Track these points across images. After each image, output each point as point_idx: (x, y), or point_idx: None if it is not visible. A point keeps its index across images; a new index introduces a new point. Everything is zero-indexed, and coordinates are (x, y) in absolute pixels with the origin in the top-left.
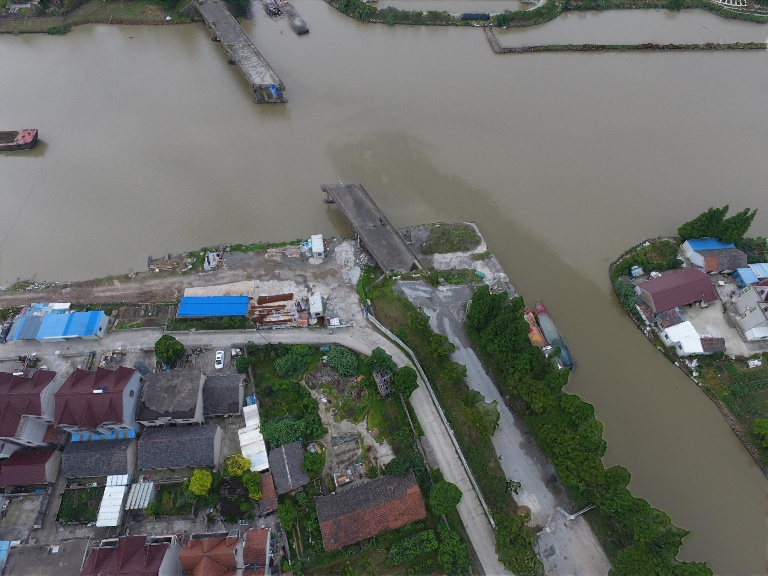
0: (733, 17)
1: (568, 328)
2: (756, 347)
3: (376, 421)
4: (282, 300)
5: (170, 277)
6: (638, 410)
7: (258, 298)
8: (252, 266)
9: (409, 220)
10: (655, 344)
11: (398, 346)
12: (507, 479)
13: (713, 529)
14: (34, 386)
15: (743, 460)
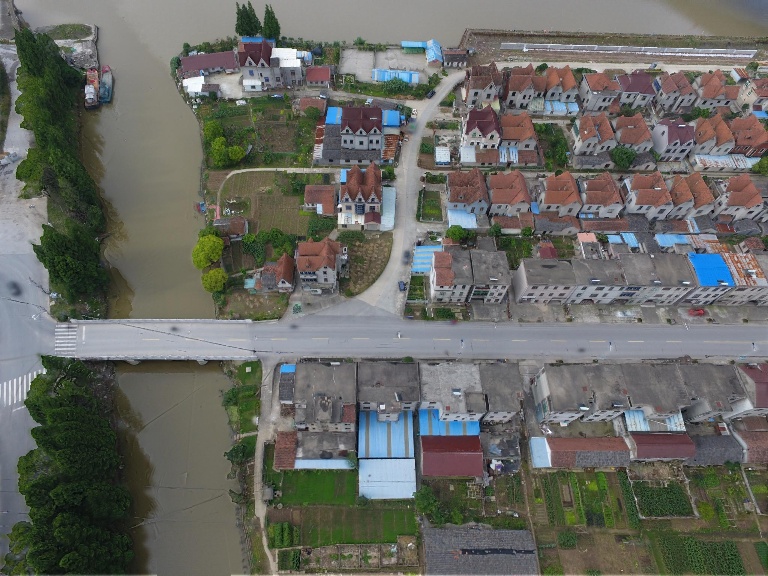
0: None
1: (129, 86)
2: (249, 95)
3: None
4: None
5: None
6: (159, 135)
7: None
8: None
9: (49, 24)
10: (180, 93)
11: None
12: (5, 140)
13: (168, 192)
14: None
15: (198, 151)
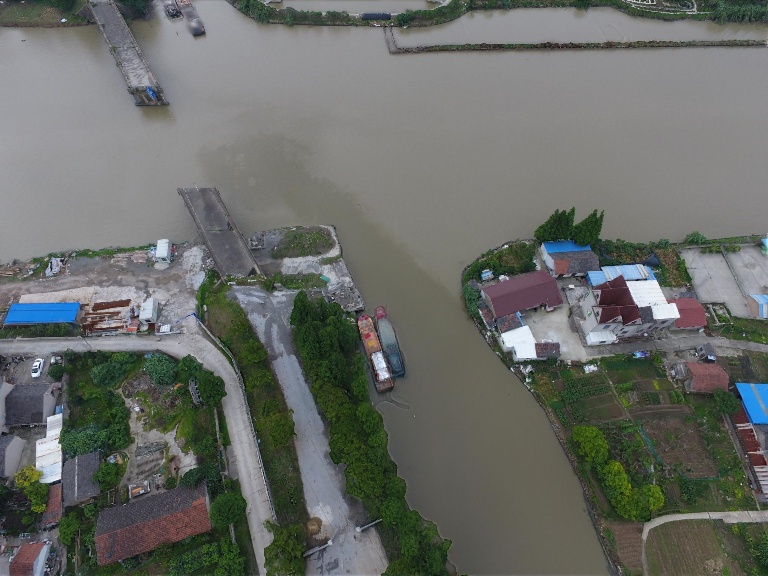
0: (640, 15)
1: (411, 333)
2: (595, 352)
3: (185, 430)
4: (118, 306)
5: (9, 283)
6: (473, 417)
7: (94, 304)
8: (95, 272)
9: (268, 224)
10: (494, 349)
11: (223, 353)
12: (304, 490)
13: (528, 539)
14: None
15: (563, 468)
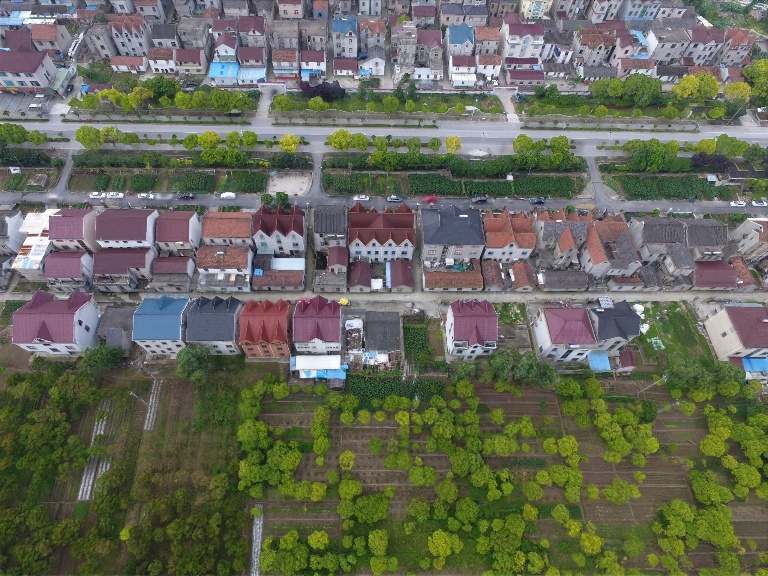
0: None
1: None
2: None
3: (759, 28)
4: None
5: None
6: None
7: None
8: None
9: None
10: None
11: (754, 7)
12: None
13: None
14: None
15: None
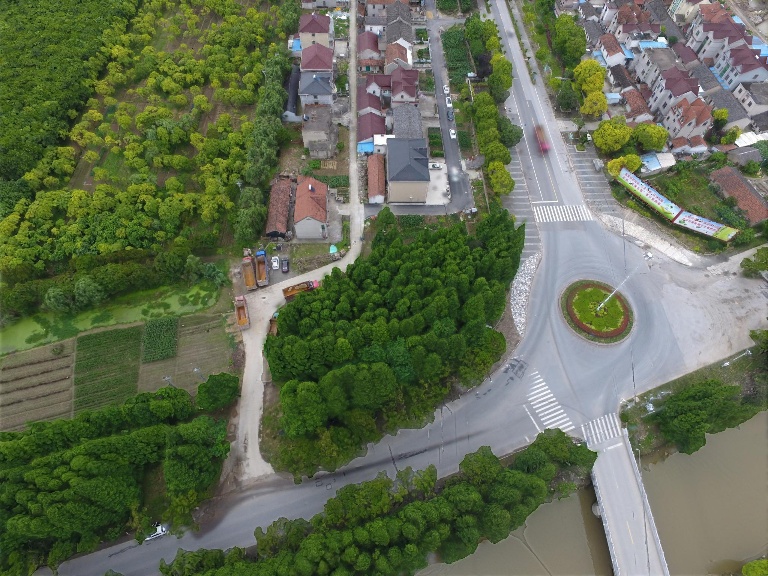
0: None
1: None
2: None
3: None
4: None
5: None
6: None
7: None
8: None
9: None
10: None
11: None
12: None
13: None
14: (744, 37)
15: None
